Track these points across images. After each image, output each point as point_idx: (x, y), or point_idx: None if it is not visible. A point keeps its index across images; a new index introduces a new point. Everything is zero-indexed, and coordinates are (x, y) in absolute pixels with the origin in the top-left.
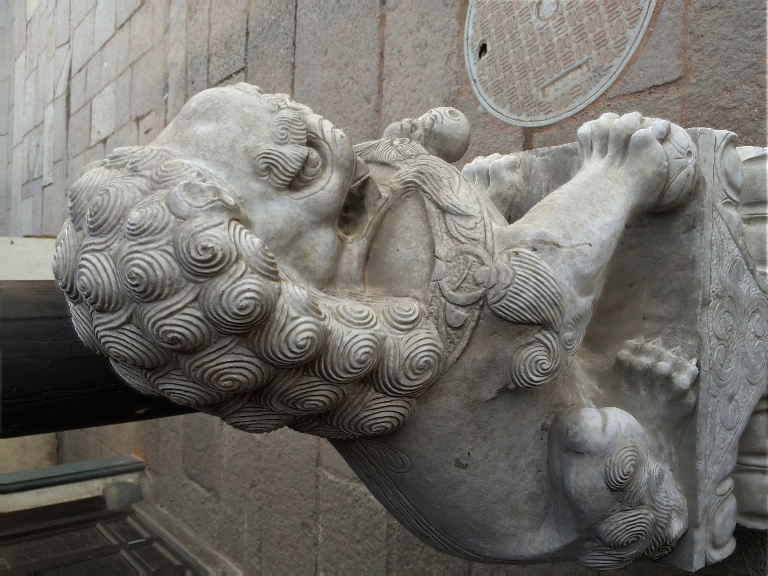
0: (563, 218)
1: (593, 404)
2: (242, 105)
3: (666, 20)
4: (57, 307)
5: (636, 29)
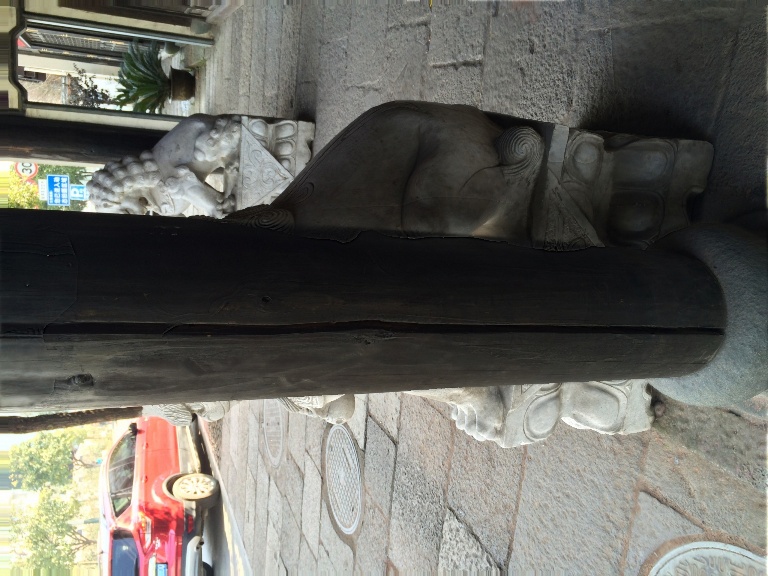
0: None
1: None
2: None
3: (642, 548)
4: None
5: (667, 569)
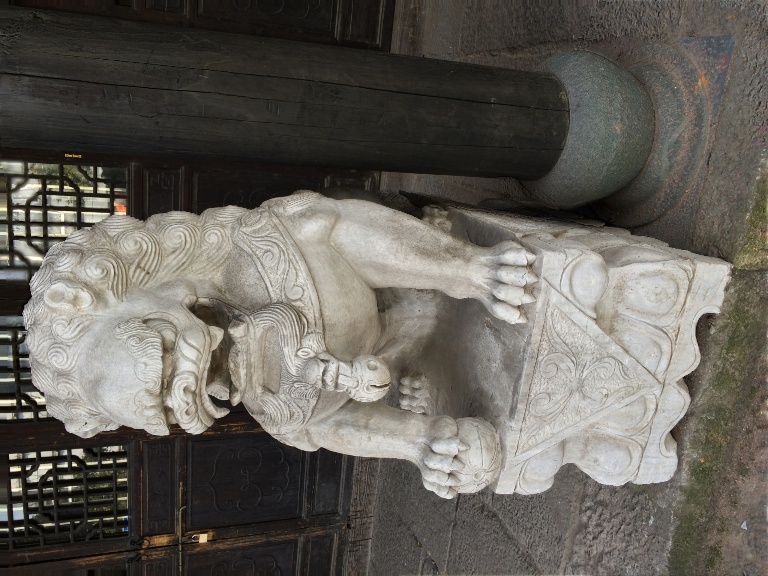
0: (339, 448)
1: (381, 357)
2: (130, 423)
3: None
4: (64, 138)
5: None
